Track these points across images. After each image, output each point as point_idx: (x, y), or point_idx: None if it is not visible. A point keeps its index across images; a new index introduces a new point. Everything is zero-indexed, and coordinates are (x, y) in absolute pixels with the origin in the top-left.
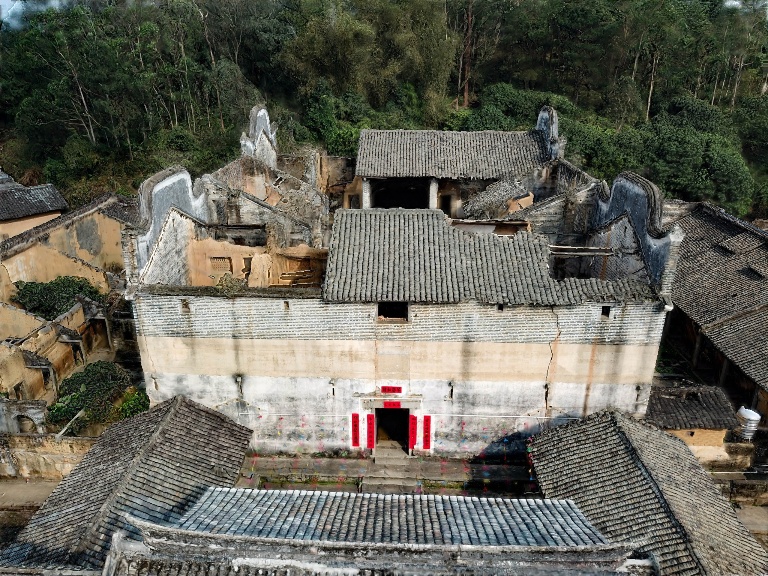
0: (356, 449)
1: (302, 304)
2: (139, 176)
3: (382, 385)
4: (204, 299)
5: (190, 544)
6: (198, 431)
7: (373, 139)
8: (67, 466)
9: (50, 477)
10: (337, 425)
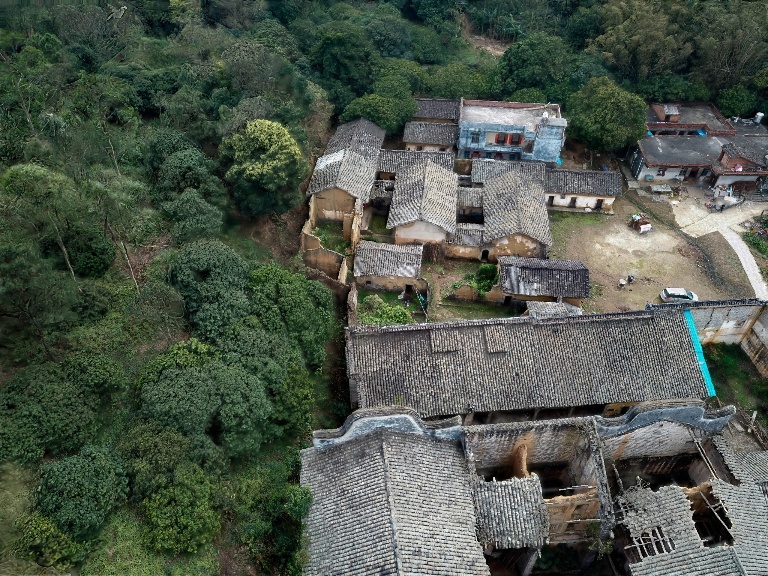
0: None
1: None
2: None
3: None
4: None
5: None
6: None
7: None
8: None
9: None
10: None
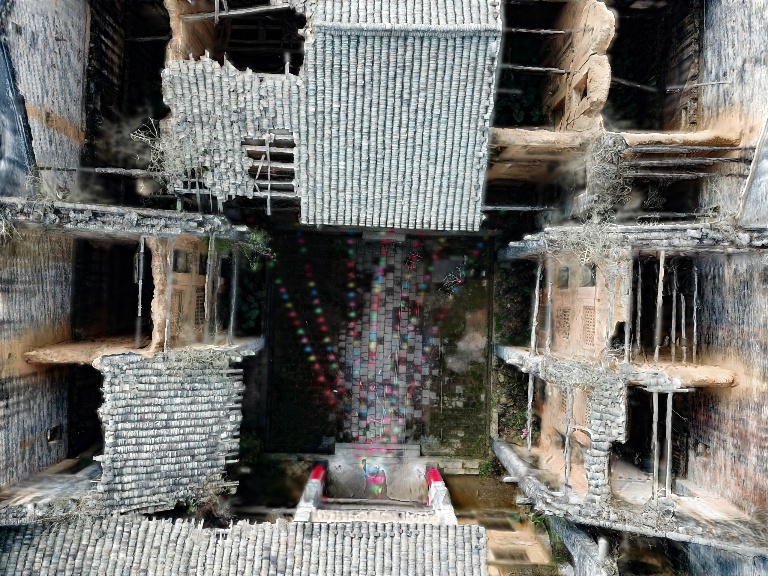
0: None
1: None
2: None
3: None
4: None
5: None
6: None
7: None
8: None
9: None
10: None
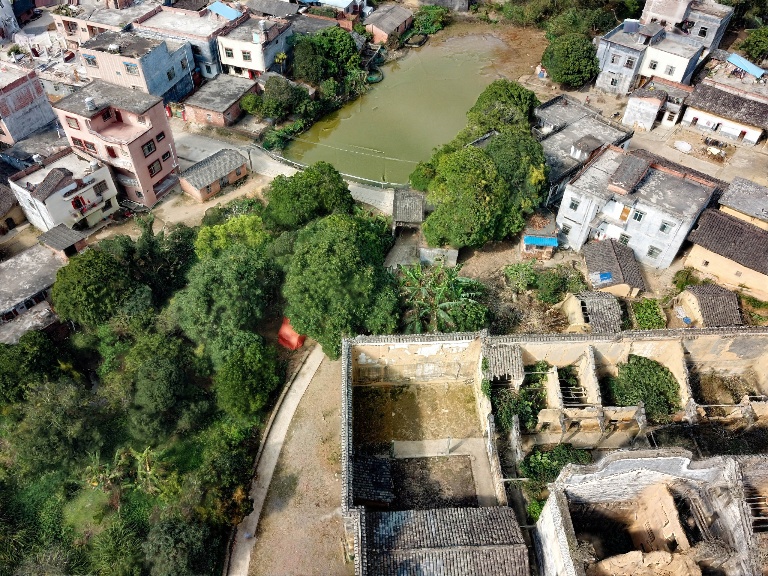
0: None
1: None
2: None
3: None
4: None
5: None
6: (506, 569)
7: None
8: (497, 491)
9: None
10: None
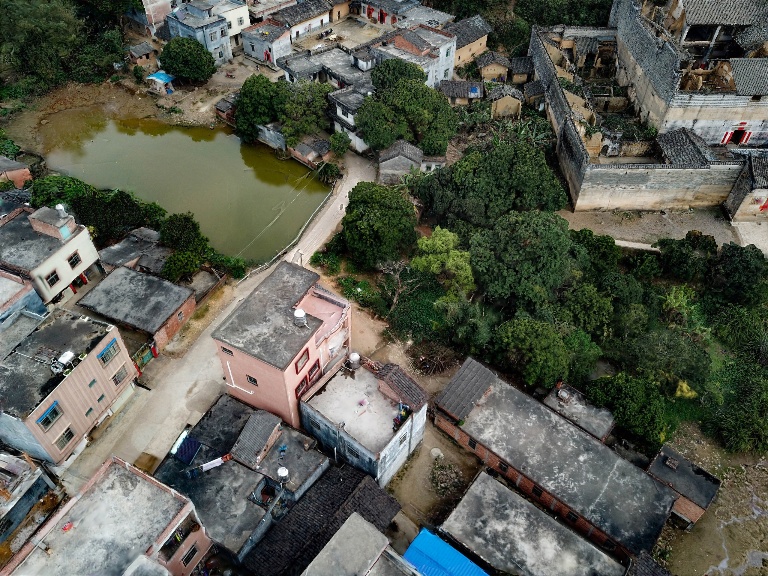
0: (722, 144)
1: (729, 96)
2: (511, 4)
3: (741, 122)
4: (698, 95)
5: (766, 153)
6: None
7: (689, 0)
8: (636, 151)
9: (629, 155)
10: (719, 136)
